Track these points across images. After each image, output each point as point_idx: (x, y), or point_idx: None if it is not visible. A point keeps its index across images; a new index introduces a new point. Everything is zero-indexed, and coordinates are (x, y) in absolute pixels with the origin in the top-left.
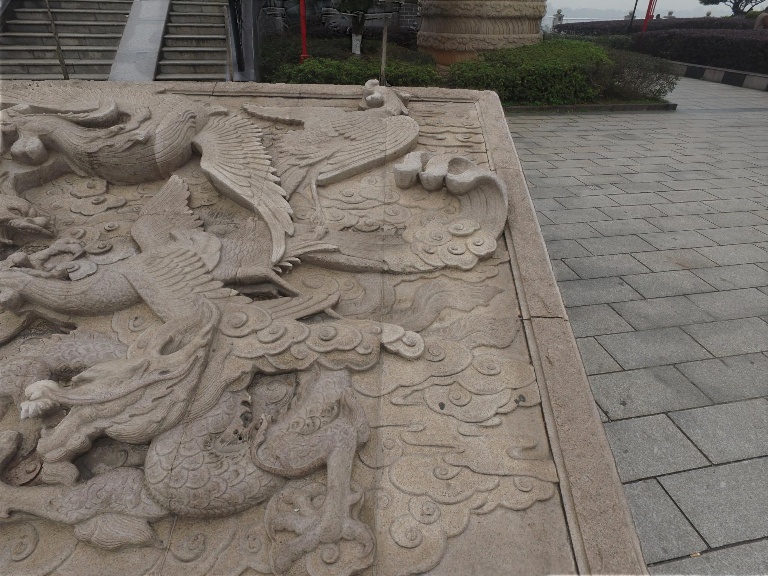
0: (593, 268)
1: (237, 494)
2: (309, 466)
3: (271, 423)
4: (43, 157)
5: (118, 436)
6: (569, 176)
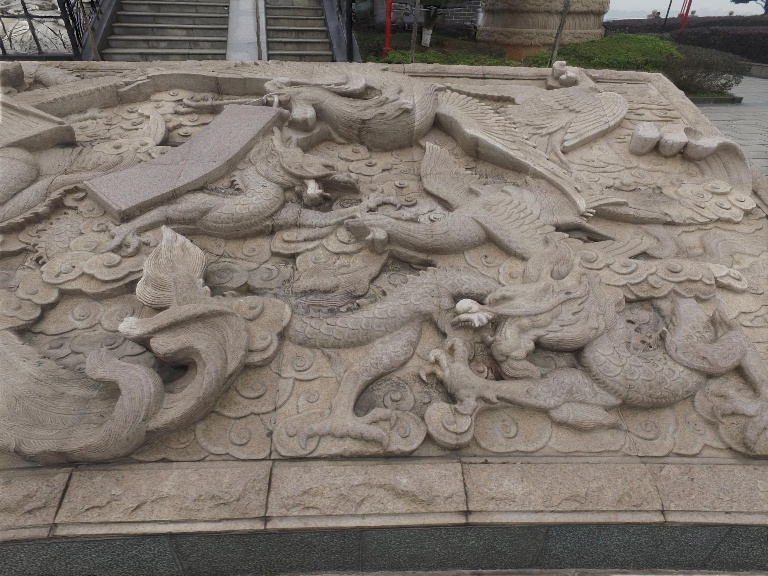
0: None
1: (678, 387)
2: (731, 365)
3: None
4: (315, 124)
5: (561, 341)
6: None
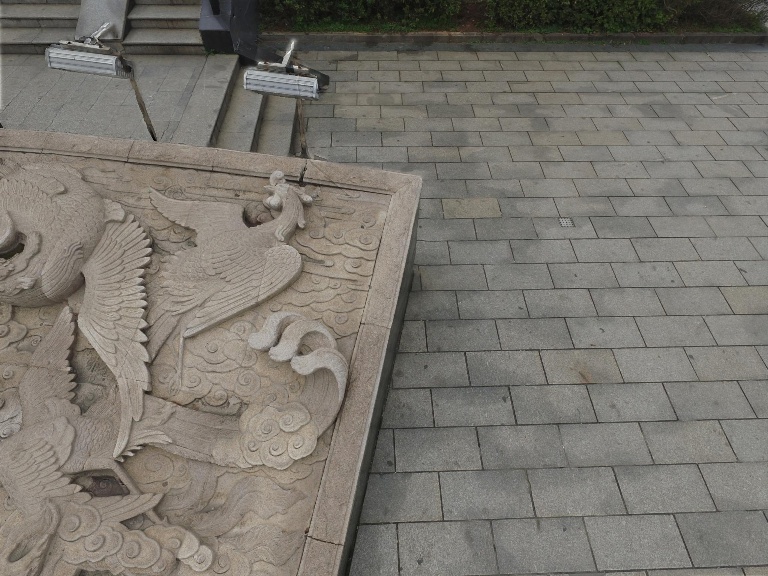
0: (490, 370)
1: None
2: None
3: None
4: None
5: None
6: (549, 197)
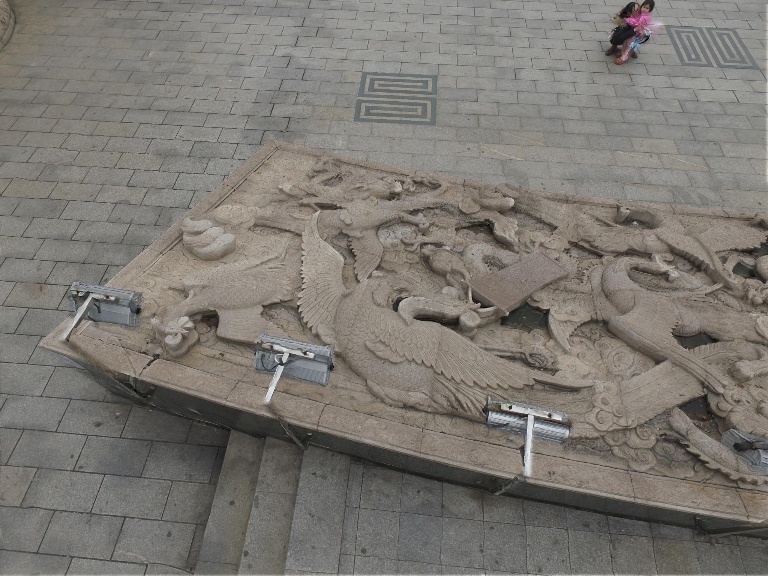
0: None
1: None
2: None
3: None
4: None
5: None
6: None
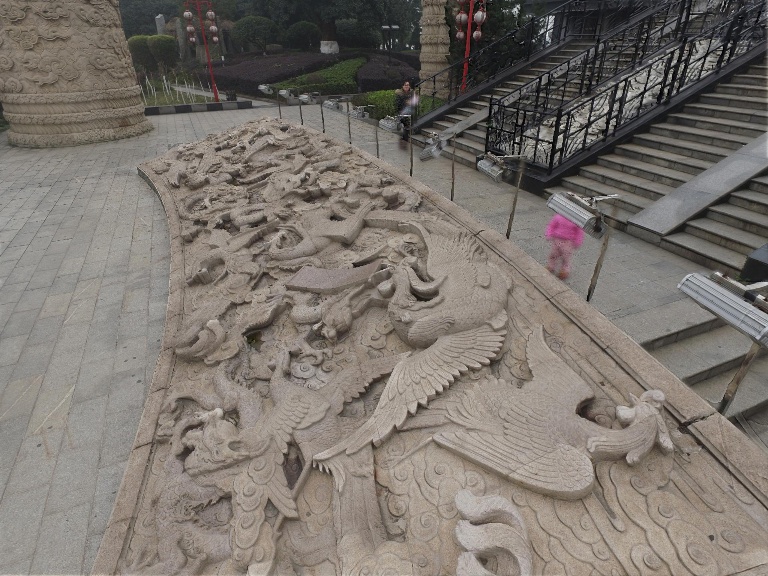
0: None
1: None
2: (158, 553)
3: (193, 521)
4: (388, 295)
5: None
6: None
